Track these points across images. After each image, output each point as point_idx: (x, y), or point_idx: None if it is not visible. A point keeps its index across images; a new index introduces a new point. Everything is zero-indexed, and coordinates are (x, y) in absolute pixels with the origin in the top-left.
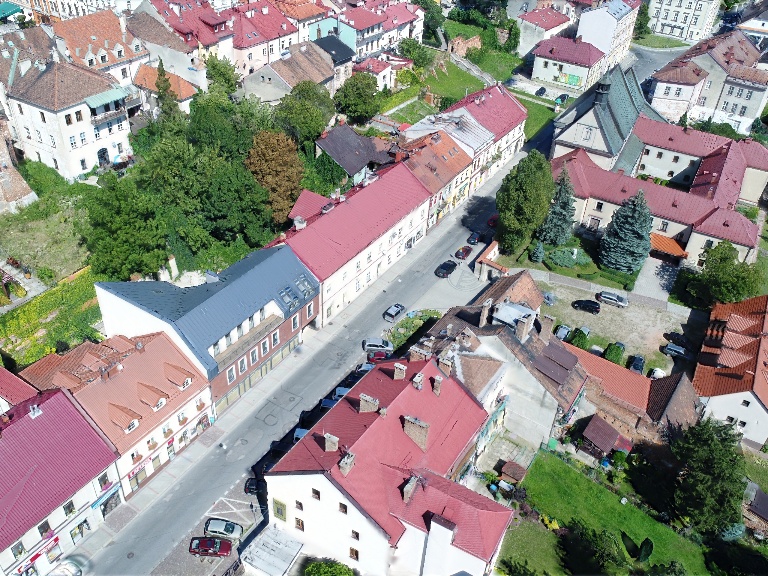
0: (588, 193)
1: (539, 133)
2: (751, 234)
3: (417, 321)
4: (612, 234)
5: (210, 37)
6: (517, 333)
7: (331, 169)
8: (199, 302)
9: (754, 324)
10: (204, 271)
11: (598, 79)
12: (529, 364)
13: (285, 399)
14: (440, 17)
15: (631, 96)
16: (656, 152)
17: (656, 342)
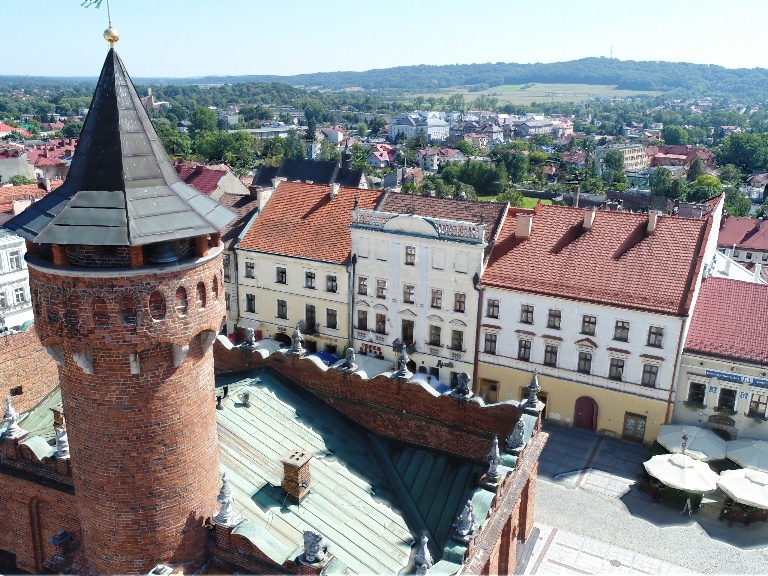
0: None
1: None
2: None
3: None
4: None
5: None
6: None
7: None
8: None
9: None
10: None
11: None
12: None
13: None
14: None
15: None
16: None
17: None
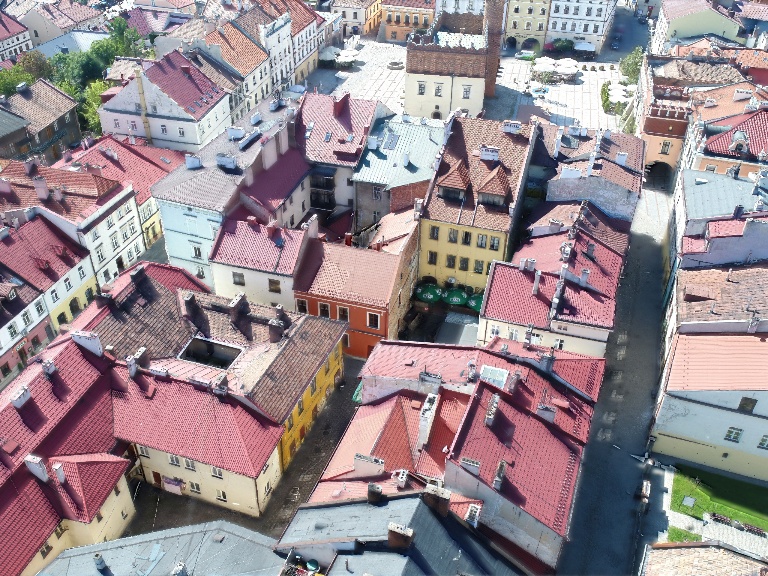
0: None
1: None
2: None
3: None
4: None
5: None
6: None
7: None
8: (65, 38)
9: None
10: None
11: None
12: None
13: None
14: None
15: None
16: None
17: None
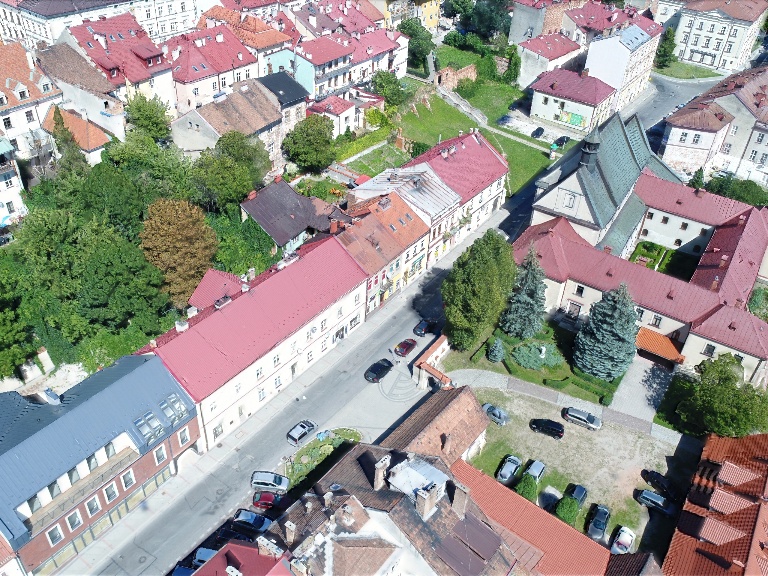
0: (566, 275)
1: (527, 185)
2: (764, 340)
3: (325, 448)
4: (588, 332)
5: (141, 72)
6: (417, 508)
7: (258, 236)
8: (16, 442)
9: (754, 478)
10: (85, 364)
11: (607, 117)
12: (430, 552)
13: (134, 559)
14: (428, 44)
15: (632, 150)
16: (661, 216)
17: (630, 483)
